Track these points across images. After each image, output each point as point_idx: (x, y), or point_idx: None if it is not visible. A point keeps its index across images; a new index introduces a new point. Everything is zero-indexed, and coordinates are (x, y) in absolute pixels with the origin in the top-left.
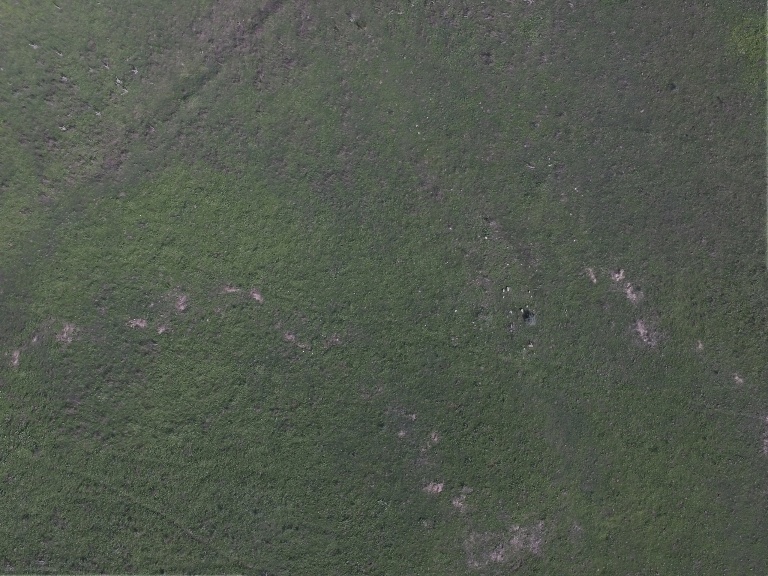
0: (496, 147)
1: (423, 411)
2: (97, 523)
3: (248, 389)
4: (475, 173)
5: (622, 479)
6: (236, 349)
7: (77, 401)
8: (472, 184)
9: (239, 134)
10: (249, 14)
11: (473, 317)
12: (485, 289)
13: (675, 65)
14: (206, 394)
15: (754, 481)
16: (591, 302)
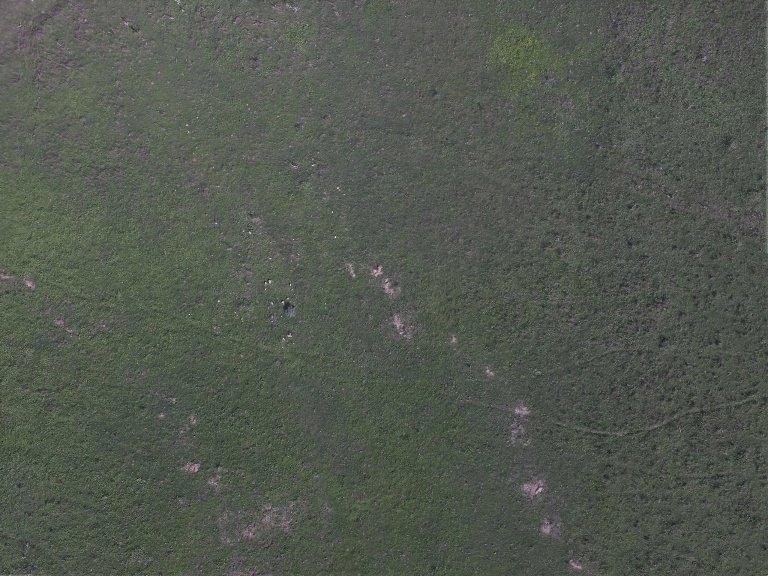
0: (262, 147)
1: (183, 395)
2: None
3: (18, 370)
4: (242, 171)
5: (373, 464)
6: (8, 332)
7: None
8: (238, 181)
9: (17, 129)
10: (30, 16)
11: (235, 307)
12: (247, 281)
13: (437, 72)
14: None
15: (501, 470)
16: (350, 296)
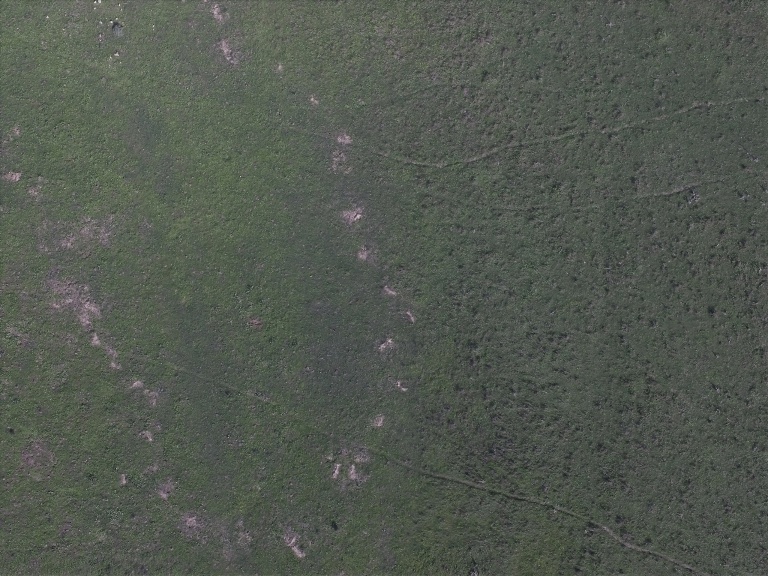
0: None
1: (8, 106)
2: None
3: None
4: None
5: (195, 184)
6: None
7: None
8: None
9: None
10: None
11: (64, 24)
12: None
13: None
14: None
15: (321, 196)
16: (178, 19)
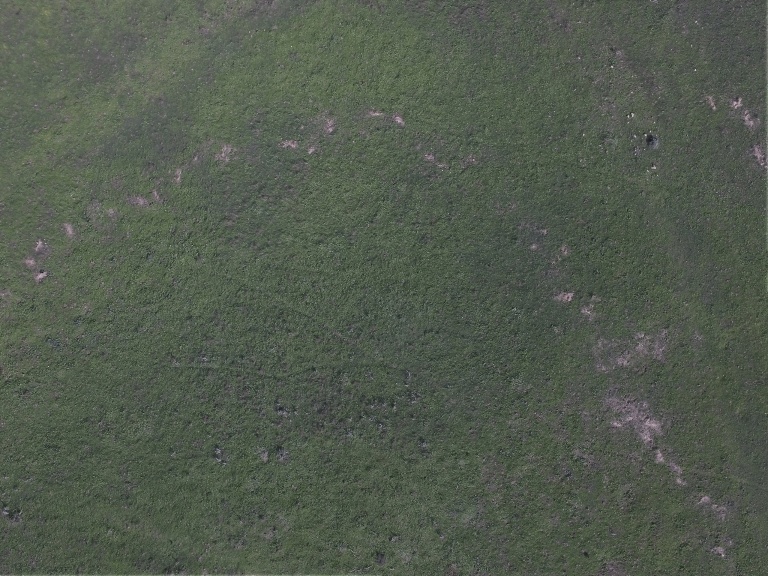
0: None
1: (554, 227)
2: (254, 325)
3: (391, 205)
4: (601, 7)
5: (740, 293)
6: (380, 168)
7: (235, 214)
8: (598, 17)
9: None
10: None
11: (600, 141)
12: (611, 114)
13: None
14: (352, 209)
15: None
16: (711, 128)
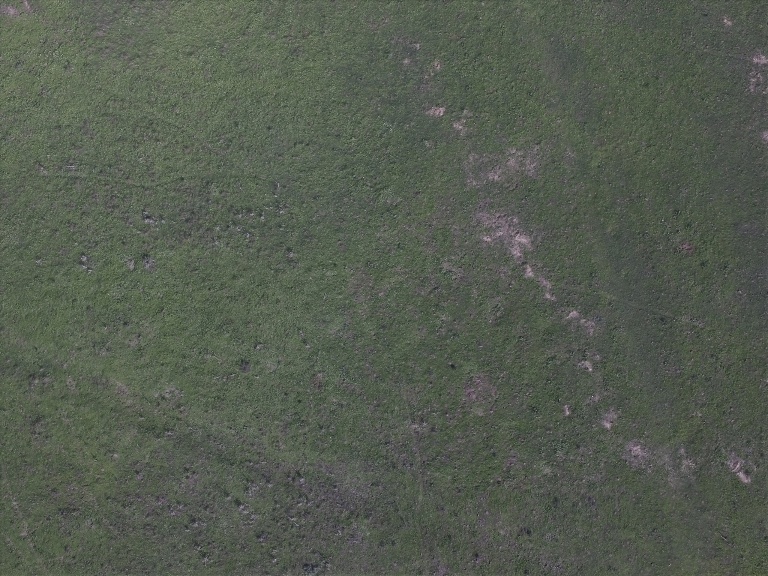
0: None
1: (427, 41)
2: (123, 135)
3: (264, 18)
4: None
5: (614, 112)
6: None
7: (106, 25)
8: None
9: None
10: None
11: None
12: None
13: None
14: (225, 22)
15: (740, 117)
16: None
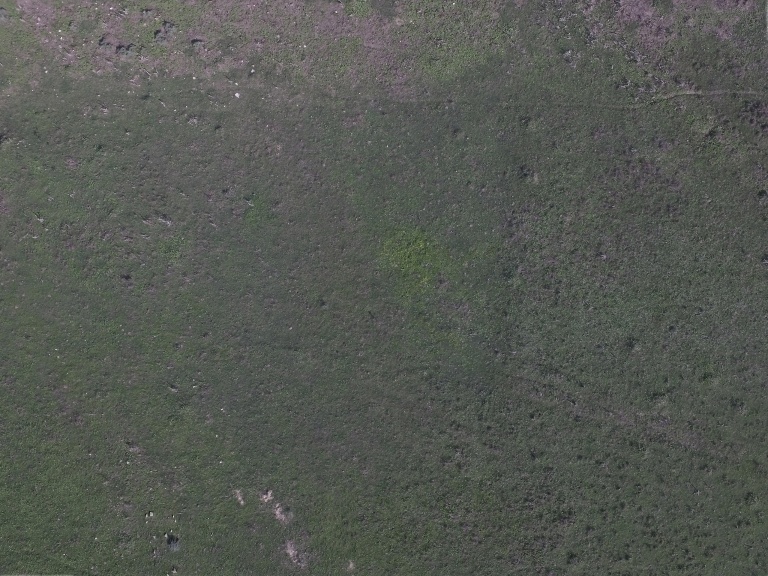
0: (138, 369)
1: None
2: None
3: None
4: (117, 396)
5: None
6: None
7: None
8: (114, 407)
9: None
10: None
11: (114, 544)
12: (126, 515)
13: (325, 281)
14: None
15: None
16: (238, 524)
